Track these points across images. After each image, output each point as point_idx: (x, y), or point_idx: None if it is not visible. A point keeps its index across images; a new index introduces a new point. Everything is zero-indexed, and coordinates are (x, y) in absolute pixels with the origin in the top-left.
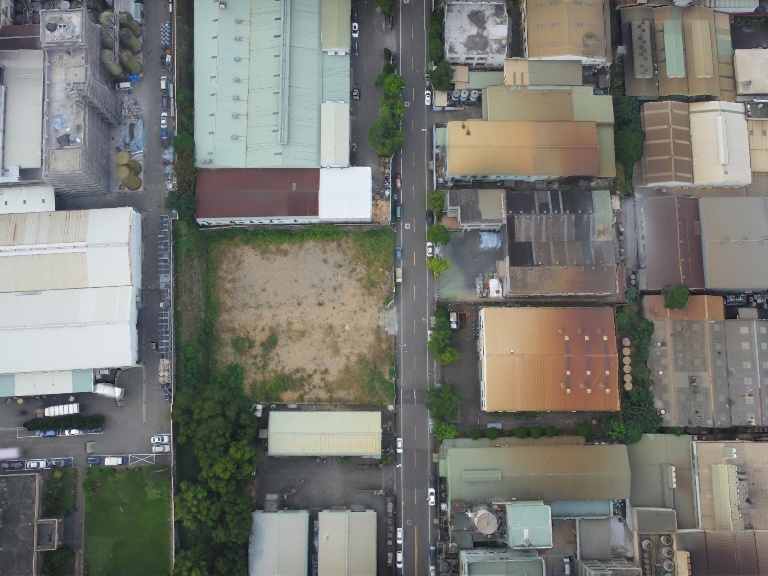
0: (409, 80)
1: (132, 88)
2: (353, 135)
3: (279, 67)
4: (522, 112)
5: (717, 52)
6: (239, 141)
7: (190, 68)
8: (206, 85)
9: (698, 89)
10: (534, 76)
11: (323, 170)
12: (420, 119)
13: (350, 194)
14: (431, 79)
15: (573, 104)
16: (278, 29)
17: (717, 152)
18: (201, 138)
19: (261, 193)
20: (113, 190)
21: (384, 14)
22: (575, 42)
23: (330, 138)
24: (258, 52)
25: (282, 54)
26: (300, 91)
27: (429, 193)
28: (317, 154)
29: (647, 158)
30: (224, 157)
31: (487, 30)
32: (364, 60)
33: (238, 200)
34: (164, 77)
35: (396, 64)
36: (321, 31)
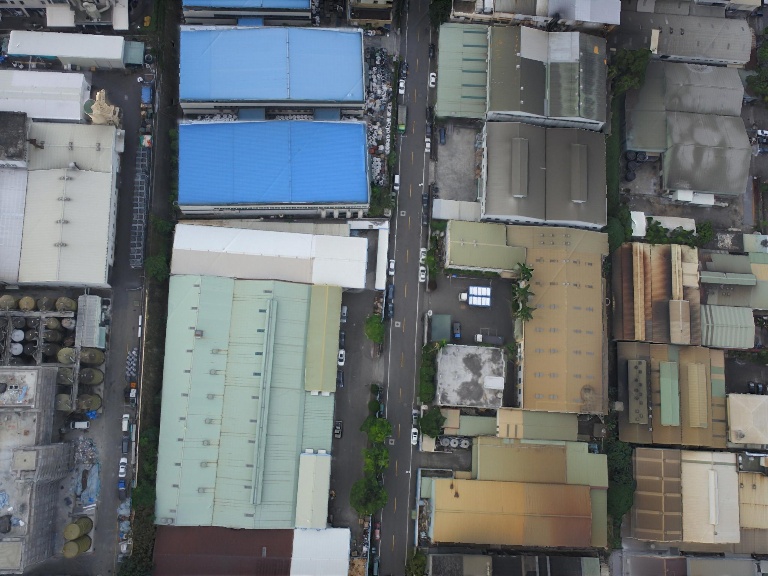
0: (395, 414)
1: (89, 426)
2: (332, 479)
3: (257, 412)
4: (514, 470)
5: (711, 396)
6: (206, 494)
7: (157, 400)
8: (173, 426)
9: (691, 438)
10: (528, 429)
11: (297, 531)
12: (405, 460)
13: (326, 563)
14: (419, 418)
15: (567, 463)
16: (258, 366)
17: (708, 510)
18: (164, 490)
19: (227, 559)
20: (58, 551)
21: (373, 340)
22: (573, 396)
23: (308, 497)
24: (234, 389)
25: (261, 399)
26: (278, 439)
27: (409, 545)
28: (292, 512)
29: (637, 510)
30: (188, 515)
31: (482, 377)
32: (349, 391)
33: (200, 566)
34: (126, 416)
35: (383, 395)
36: (305, 368)
